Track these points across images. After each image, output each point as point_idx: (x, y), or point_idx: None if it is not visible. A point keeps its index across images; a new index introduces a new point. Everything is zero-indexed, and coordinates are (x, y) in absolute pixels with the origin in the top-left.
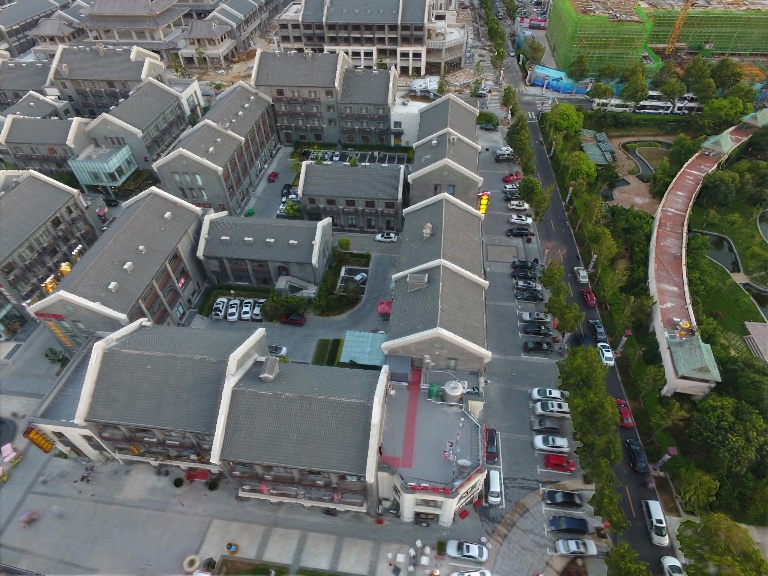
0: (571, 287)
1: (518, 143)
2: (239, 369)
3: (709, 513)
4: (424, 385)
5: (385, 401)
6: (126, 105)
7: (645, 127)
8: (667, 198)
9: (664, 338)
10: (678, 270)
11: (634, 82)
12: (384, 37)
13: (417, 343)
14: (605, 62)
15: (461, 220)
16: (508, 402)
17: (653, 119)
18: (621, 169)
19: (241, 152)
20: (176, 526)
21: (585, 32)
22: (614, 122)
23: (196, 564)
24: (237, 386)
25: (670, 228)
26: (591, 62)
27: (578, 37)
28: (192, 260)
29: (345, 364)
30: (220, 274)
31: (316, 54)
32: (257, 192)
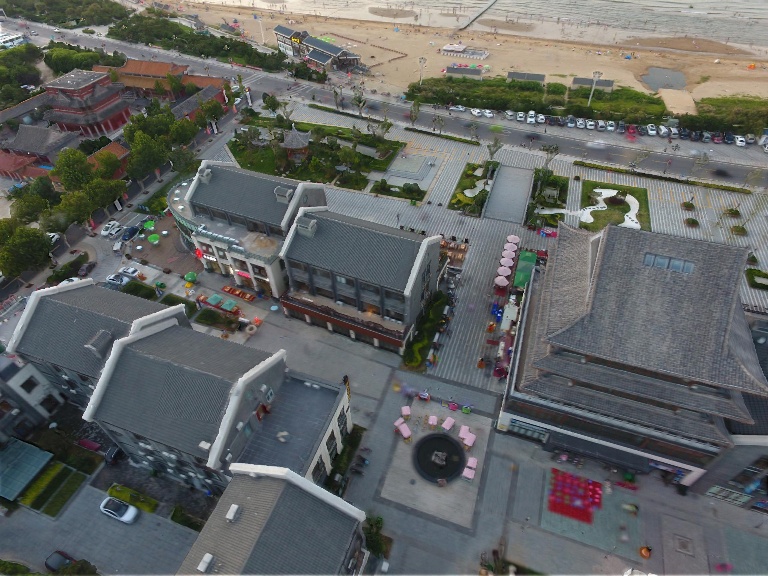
0: None
1: None
2: None
3: None
4: None
5: None
6: None
7: None
8: None
9: None
10: None
11: None
12: None
13: None
14: None
15: None
16: None
17: None
18: None
19: None
20: None
21: None
22: None
23: (248, 328)
24: None
25: None
26: None
27: None
28: None
29: (50, 447)
30: None
31: None
32: None
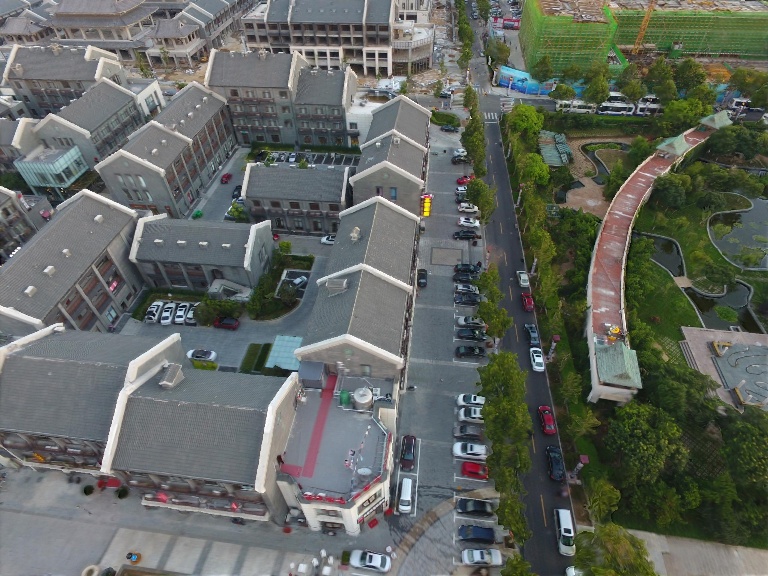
0: (511, 291)
1: (470, 145)
2: (141, 376)
3: (608, 524)
4: (337, 392)
5: (295, 408)
6: (76, 105)
7: (607, 128)
8: (616, 201)
9: (593, 344)
10: (617, 274)
11: (595, 83)
12: (349, 37)
13: (327, 349)
14: (571, 63)
15: (393, 223)
16: (433, 408)
17: (615, 120)
18: (578, 171)
19: (189, 153)
20: (81, 535)
21: (550, 33)
22: (575, 123)
23: (94, 574)
24: (134, 394)
25: (615, 231)
26: (557, 63)
27: (543, 38)
28: (126, 263)
29: (270, 369)
30: (156, 277)
31: (270, 54)
32: (208, 194)
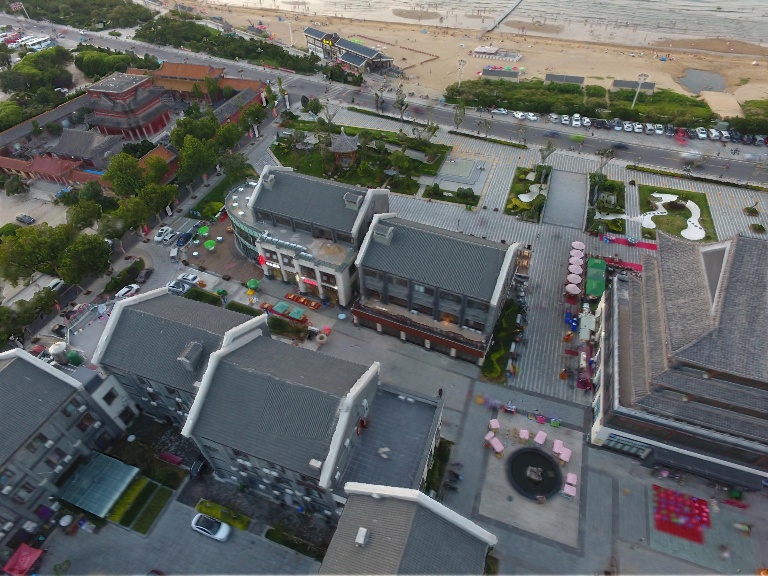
0: None
1: None
2: None
3: None
4: None
5: None
6: None
7: None
8: None
9: None
10: None
11: None
12: None
13: None
14: None
15: None
16: None
17: None
18: None
19: None
20: None
21: None
22: None
23: (318, 337)
24: None
25: None
26: None
27: None
28: None
29: (135, 461)
30: None
31: None
32: None
